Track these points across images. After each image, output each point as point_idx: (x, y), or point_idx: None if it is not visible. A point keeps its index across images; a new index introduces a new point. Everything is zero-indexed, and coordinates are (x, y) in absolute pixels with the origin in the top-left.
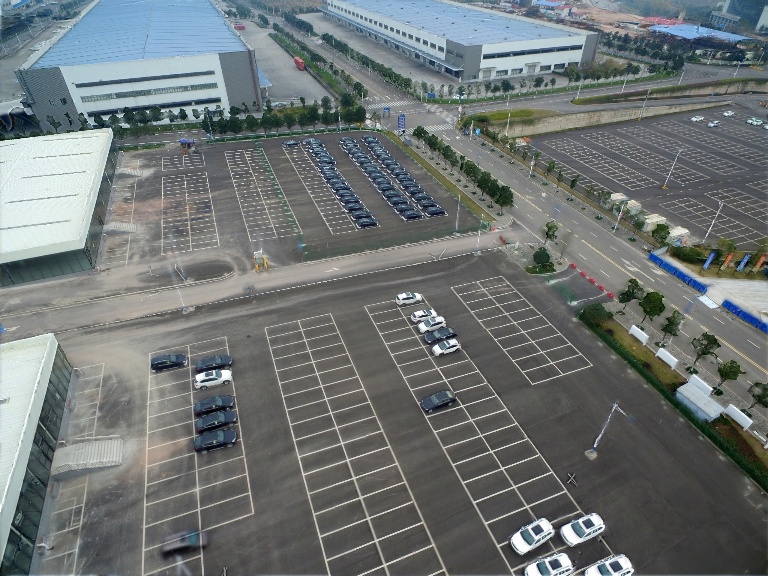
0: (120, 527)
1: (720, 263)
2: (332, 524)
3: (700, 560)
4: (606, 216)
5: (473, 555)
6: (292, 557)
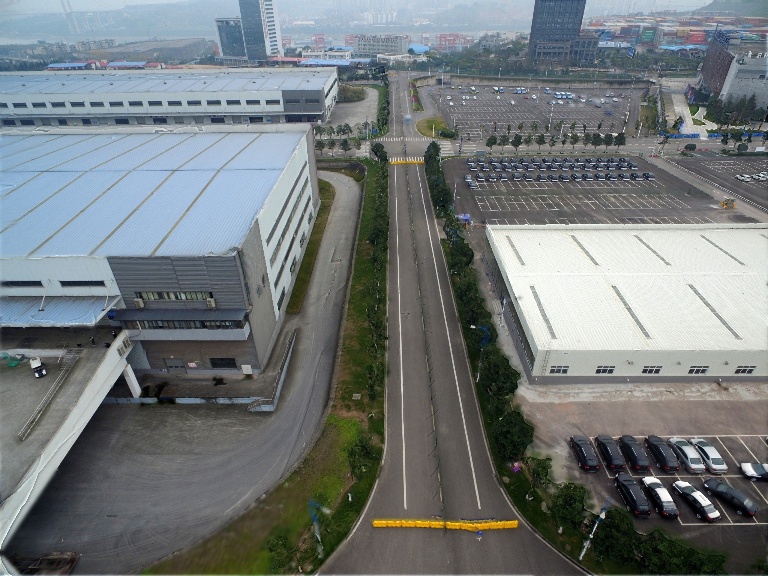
0: None
1: (678, 128)
2: None
3: None
4: None
5: None
6: None
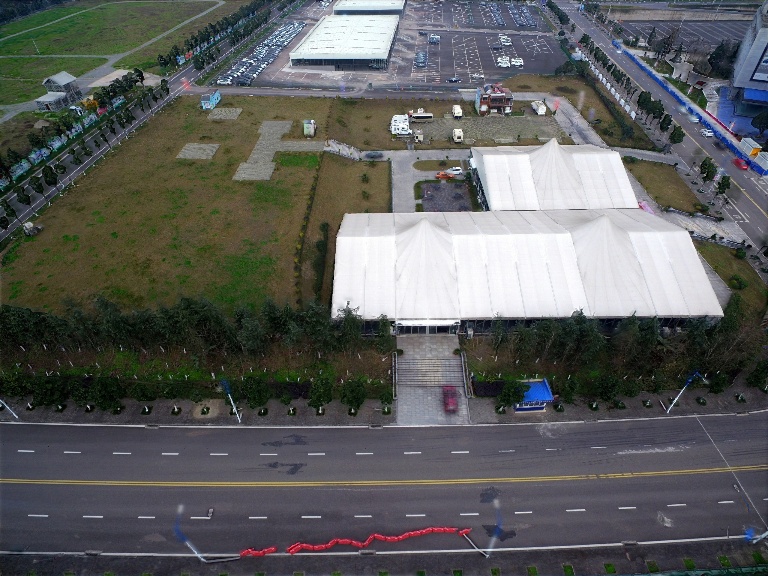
0: None
1: None
2: None
3: None
4: None
5: None
6: None
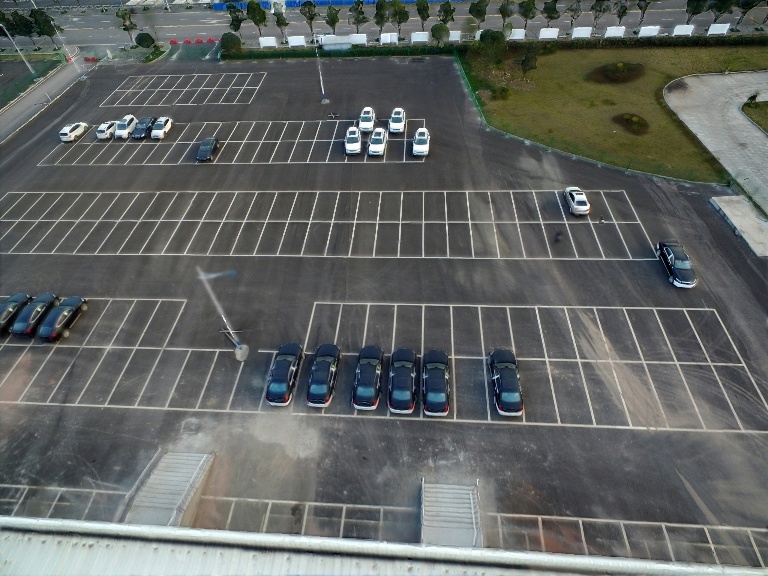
0: (79, 434)
1: None
2: (250, 245)
3: (416, 93)
4: (149, 5)
5: (341, 175)
6: (255, 277)
